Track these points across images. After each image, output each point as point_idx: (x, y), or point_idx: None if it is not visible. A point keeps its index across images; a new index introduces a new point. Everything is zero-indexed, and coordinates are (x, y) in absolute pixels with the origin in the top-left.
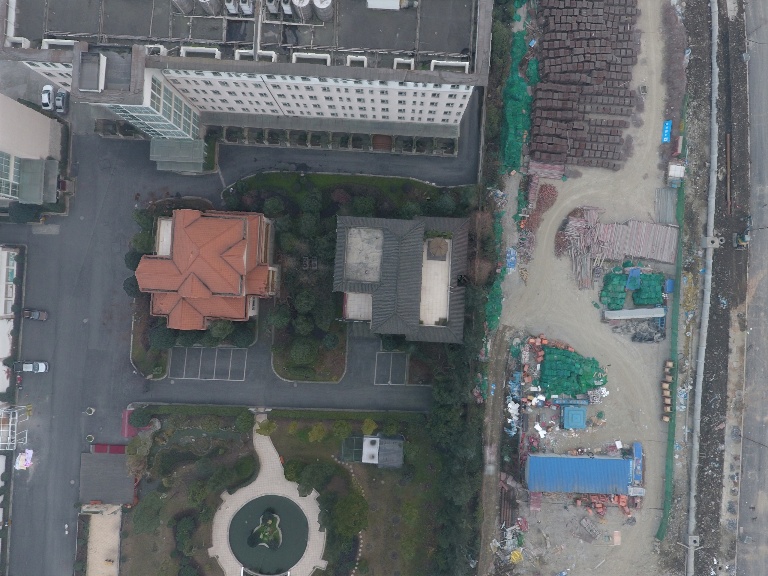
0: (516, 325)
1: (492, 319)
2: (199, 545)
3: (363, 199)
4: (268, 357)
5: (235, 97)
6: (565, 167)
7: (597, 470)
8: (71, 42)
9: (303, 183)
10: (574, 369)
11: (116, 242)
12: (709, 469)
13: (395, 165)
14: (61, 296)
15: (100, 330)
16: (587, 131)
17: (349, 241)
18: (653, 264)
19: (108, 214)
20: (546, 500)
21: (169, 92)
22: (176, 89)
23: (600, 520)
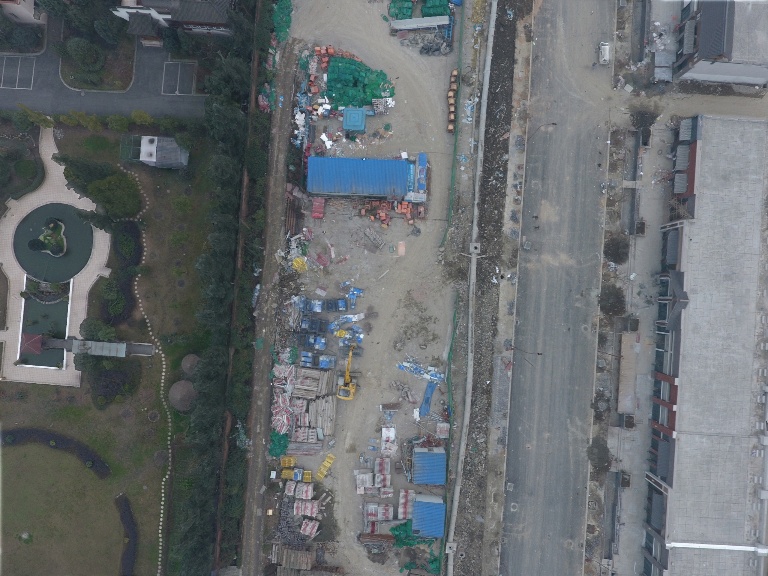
0: (305, 38)
1: (280, 30)
2: None
3: None
4: (56, 66)
5: None
6: None
7: (375, 170)
8: None
9: None
10: (358, 75)
11: None
12: (493, 179)
13: None
14: None
15: None
16: None
17: None
18: None
19: None
20: (331, 211)
21: None
22: None
23: (385, 231)
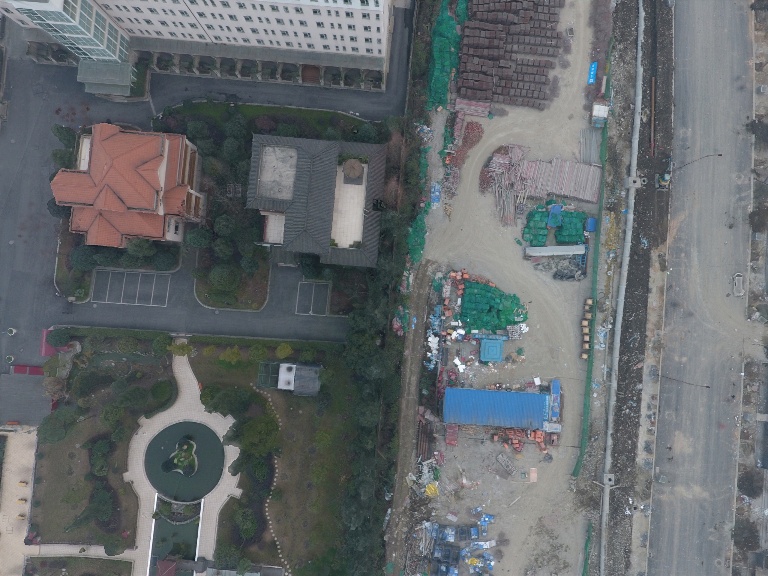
0: (439, 259)
1: (415, 252)
2: (114, 469)
3: (286, 126)
4: (191, 284)
5: (158, 17)
6: (491, 104)
7: (512, 403)
8: None
9: (231, 112)
10: (494, 303)
11: (45, 166)
12: (627, 408)
13: (324, 98)
14: None
15: (25, 252)
16: (514, 70)
17: (264, 159)
18: (576, 203)
19: (39, 138)
20: (463, 435)
21: (89, 5)
22: (98, 5)
23: None
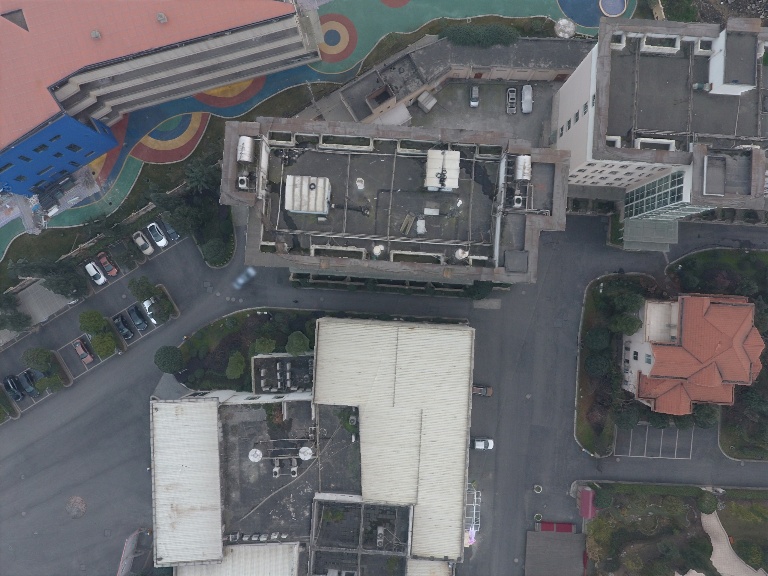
0: None
1: None
2: None
3: None
4: (715, 435)
5: None
6: None
7: None
8: (668, 141)
9: (753, 261)
10: None
11: (559, 317)
12: None
13: None
14: (503, 371)
15: (543, 406)
16: None
17: None
18: None
19: (550, 289)
20: None
21: None
22: None
23: None
